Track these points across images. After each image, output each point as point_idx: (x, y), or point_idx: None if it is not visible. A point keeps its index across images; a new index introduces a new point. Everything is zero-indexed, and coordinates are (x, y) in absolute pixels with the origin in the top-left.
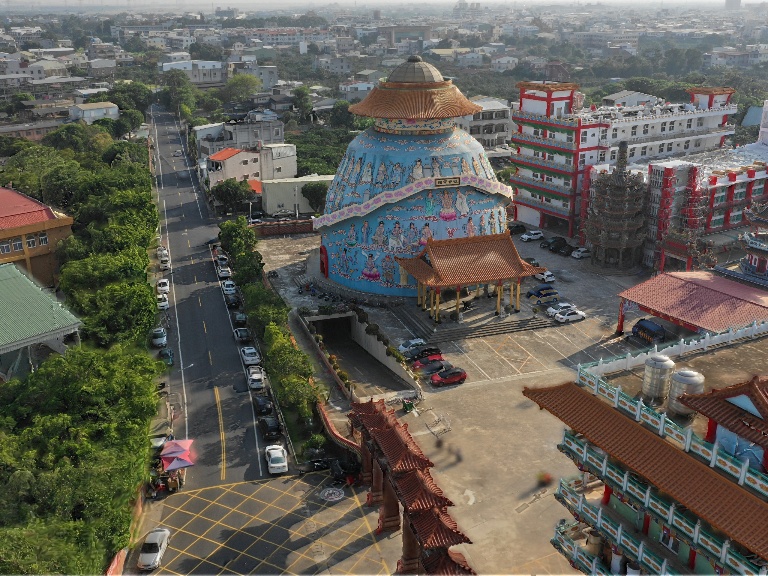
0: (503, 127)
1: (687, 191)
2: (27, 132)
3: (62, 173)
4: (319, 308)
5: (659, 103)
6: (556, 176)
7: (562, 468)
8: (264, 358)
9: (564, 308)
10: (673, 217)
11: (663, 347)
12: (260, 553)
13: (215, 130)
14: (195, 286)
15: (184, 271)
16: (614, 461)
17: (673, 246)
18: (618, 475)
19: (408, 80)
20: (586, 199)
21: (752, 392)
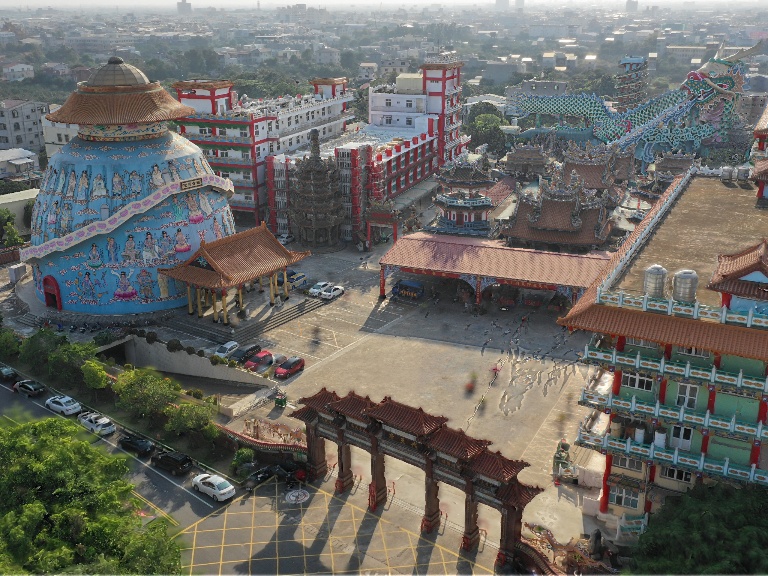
0: None
1: (367, 168)
2: None
3: None
4: (95, 340)
5: (245, 99)
6: (234, 171)
7: (453, 409)
8: (82, 403)
9: (324, 286)
10: (361, 193)
11: (425, 299)
12: (294, 569)
13: None
14: None
15: None
16: (645, 354)
17: (378, 217)
18: (654, 363)
19: (119, 83)
20: (273, 189)
21: (763, 268)
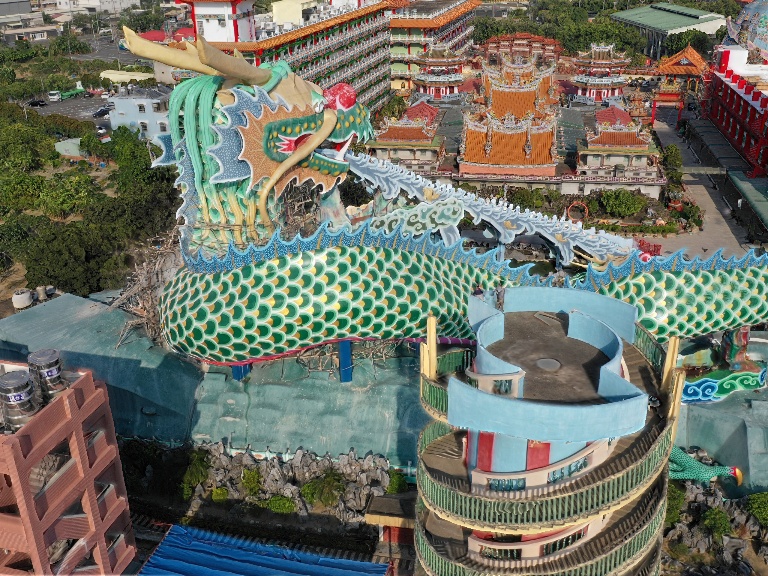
0: None
1: None
2: None
3: None
4: None
5: None
6: None
7: None
8: None
9: None
10: None
11: None
12: None
13: None
14: None
15: None
16: None
17: None
18: None
19: None
20: None
21: None
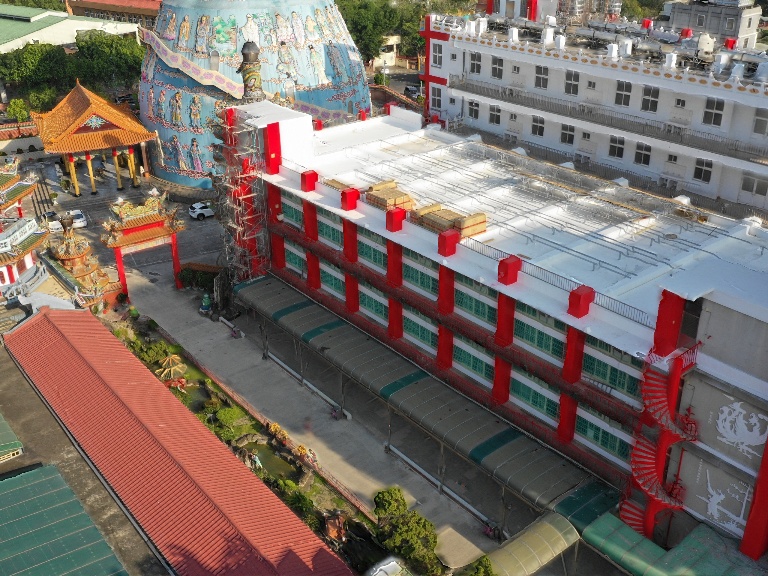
0: None
1: None
2: None
3: None
4: None
5: None
6: None
7: None
8: None
9: None
10: None
11: None
12: None
13: None
14: None
15: None
16: None
17: None
18: None
19: None
20: None
21: None
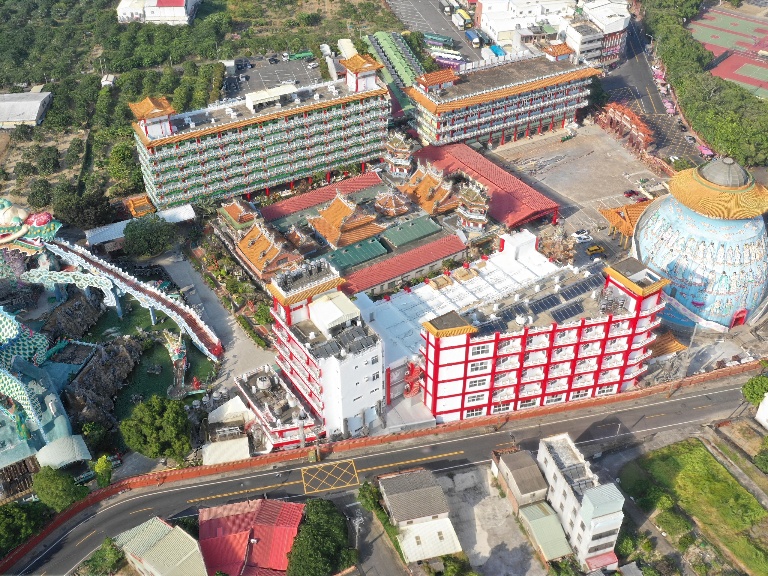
0: None
1: None
2: None
3: None
4: None
5: None
6: None
7: None
8: None
9: None
10: None
11: None
12: None
13: None
14: None
15: None
16: None
17: None
18: None
19: None
20: None
21: None
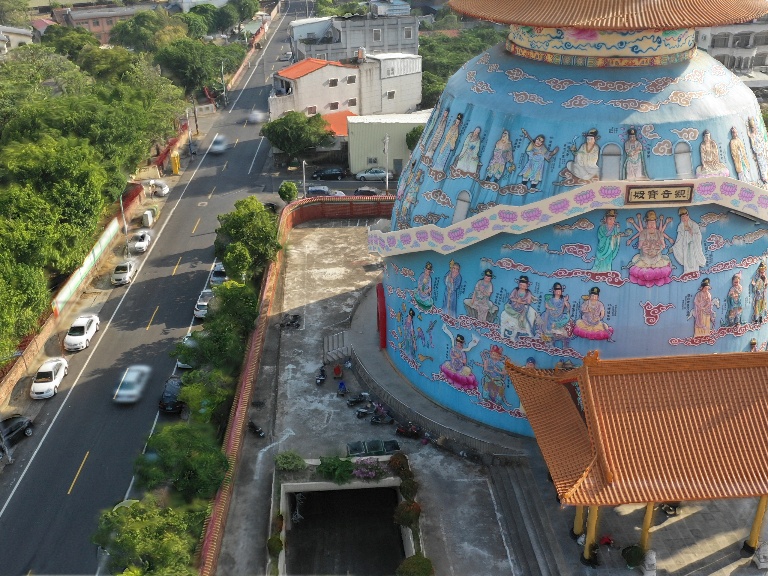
0: (767, 37)
1: None
2: (108, 20)
3: (0, 96)
4: None
5: None
6: None
7: None
8: None
9: None
10: None
11: None
12: None
13: (320, 27)
14: (140, 336)
15: (147, 292)
16: None
17: None
18: None
19: None
20: None
21: None
